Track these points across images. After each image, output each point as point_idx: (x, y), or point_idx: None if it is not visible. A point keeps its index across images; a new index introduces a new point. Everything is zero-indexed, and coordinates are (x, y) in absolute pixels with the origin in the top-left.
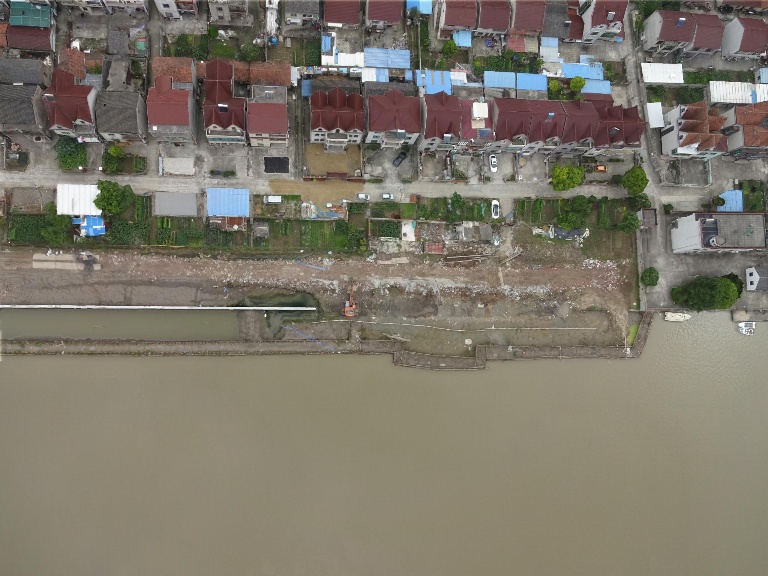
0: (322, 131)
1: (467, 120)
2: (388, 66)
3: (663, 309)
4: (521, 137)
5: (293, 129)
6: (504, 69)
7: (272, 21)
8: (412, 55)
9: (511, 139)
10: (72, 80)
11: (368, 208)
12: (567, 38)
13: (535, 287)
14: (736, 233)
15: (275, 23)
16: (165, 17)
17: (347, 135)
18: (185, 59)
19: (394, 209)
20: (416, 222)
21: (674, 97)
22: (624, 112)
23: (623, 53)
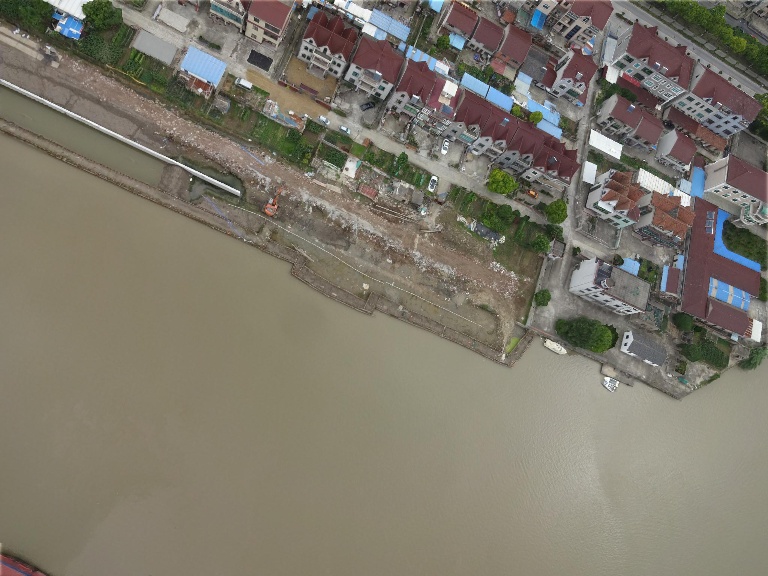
0: (312, 44)
1: (437, 93)
2: (388, 31)
3: (545, 334)
4: (476, 129)
5: (287, 40)
6: None
7: None
8: (411, 33)
9: (467, 126)
10: None
11: (324, 133)
12: (540, 82)
13: (442, 265)
14: (625, 288)
15: None
16: None
17: (332, 58)
18: None
19: (346, 143)
20: (361, 163)
21: (609, 169)
22: (565, 152)
23: (580, 117)
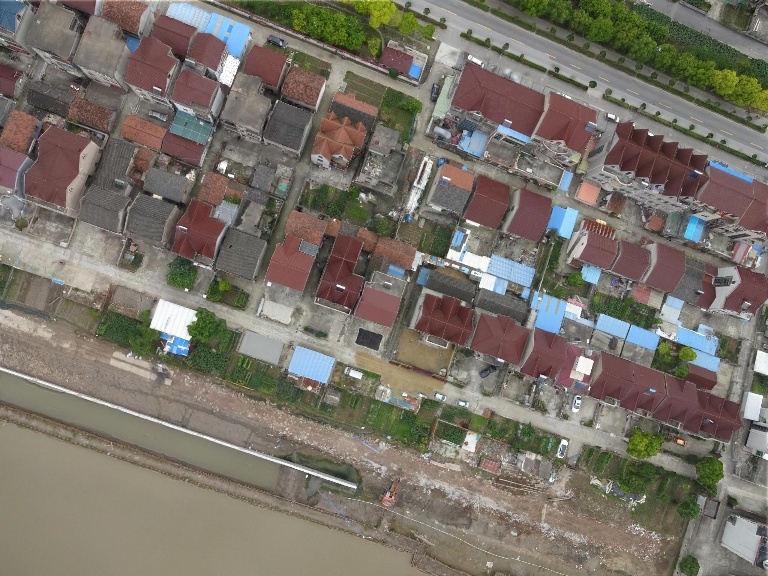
0: None
1: (568, 367)
2: (509, 279)
3: None
4: None
5: None
6: (620, 312)
7: (414, 201)
8: (536, 275)
9: (604, 398)
10: (209, 211)
11: (440, 407)
12: (693, 304)
13: (573, 534)
14: None
15: (416, 202)
16: (315, 164)
17: (447, 343)
18: (320, 221)
19: (465, 417)
20: (481, 436)
21: None
22: (724, 403)
23: (743, 332)
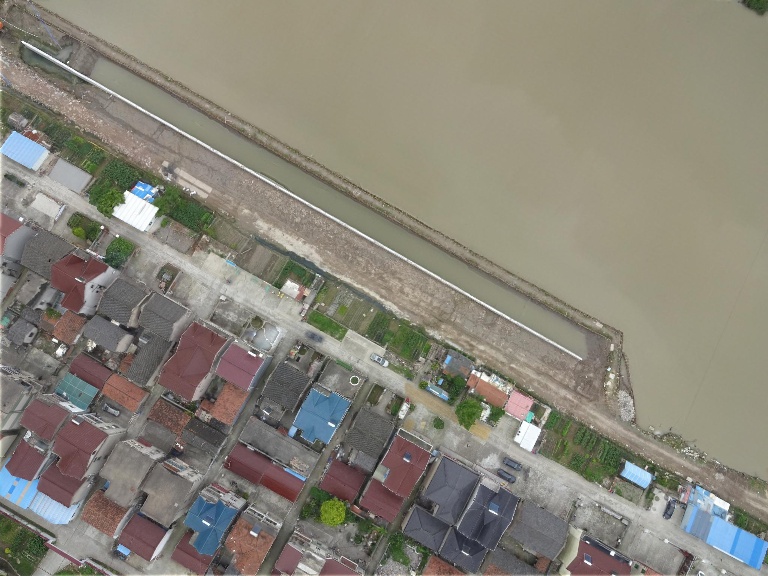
0: None
1: None
2: None
3: None
4: None
5: None
6: None
7: None
8: None
9: None
10: None
11: None
12: None
13: None
14: None
15: None
16: None
17: None
18: None
19: None
20: None
21: None
22: None
23: None
